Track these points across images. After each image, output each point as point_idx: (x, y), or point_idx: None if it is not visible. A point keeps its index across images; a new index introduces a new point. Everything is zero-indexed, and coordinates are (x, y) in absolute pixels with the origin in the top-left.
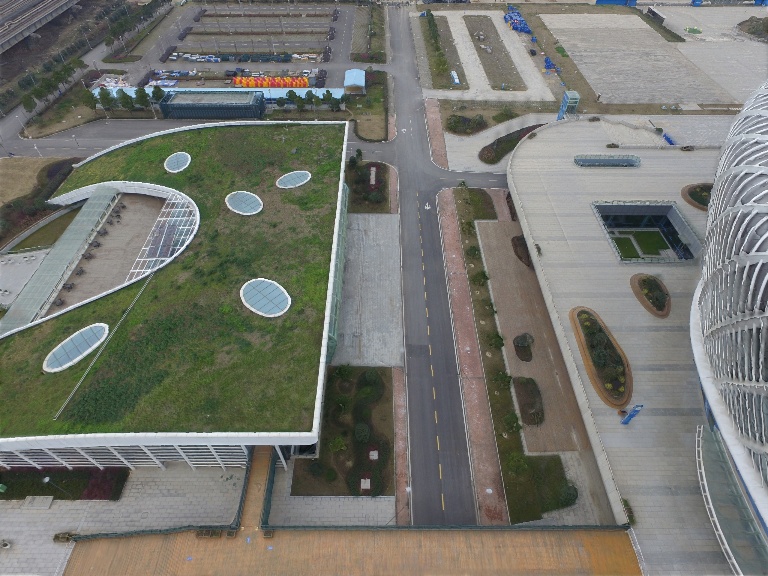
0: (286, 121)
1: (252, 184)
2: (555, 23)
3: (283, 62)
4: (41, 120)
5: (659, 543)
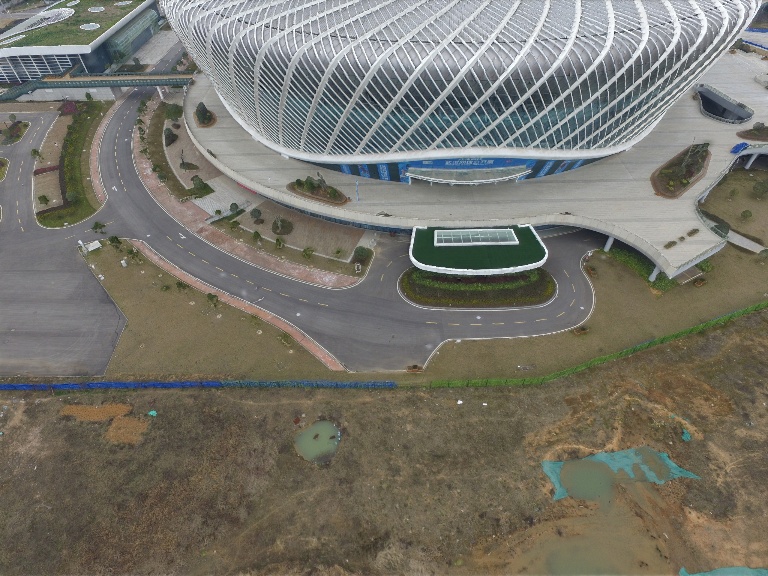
0: None
1: (103, 5)
2: None
3: None
4: (14, 5)
5: None
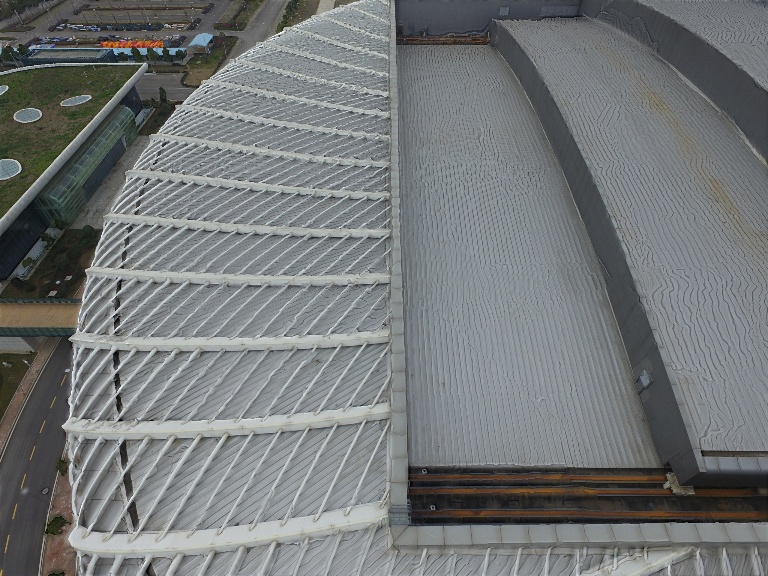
0: (96, 63)
1: (42, 104)
2: None
3: (154, 30)
4: None
5: None
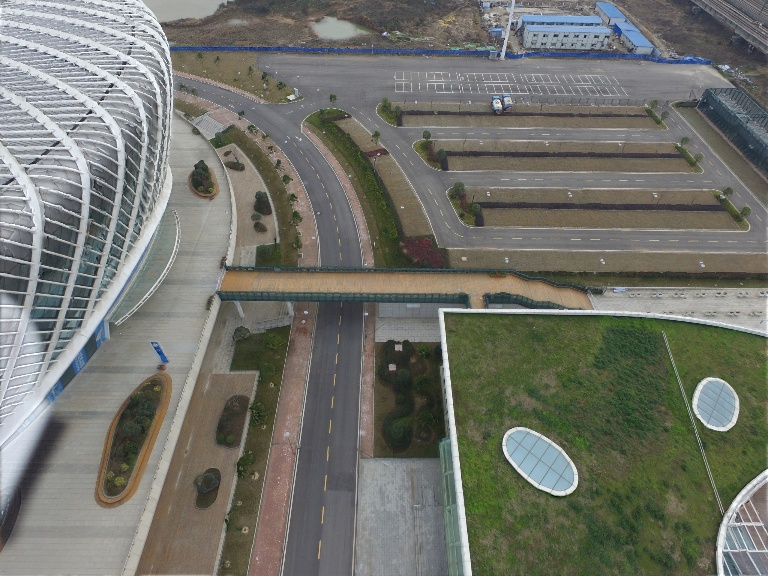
0: None
1: None
2: None
3: None
4: None
5: (202, 289)
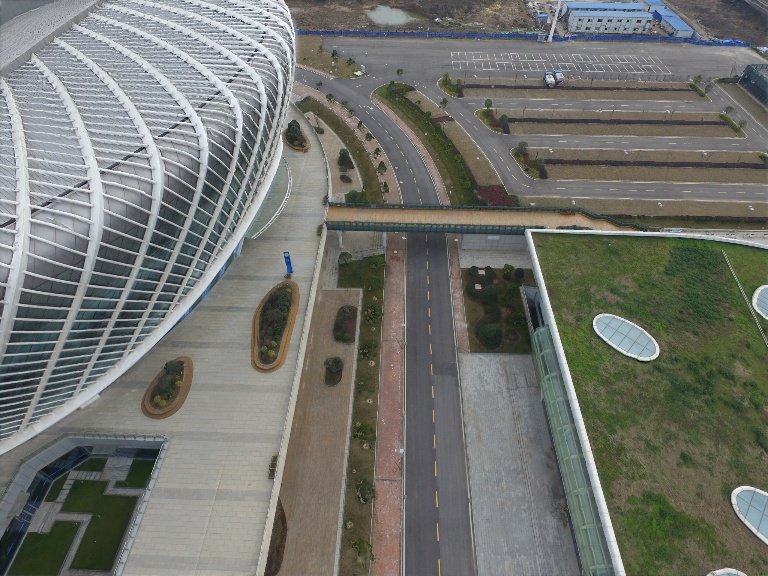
0: None
1: None
2: None
3: None
4: None
5: (310, 220)
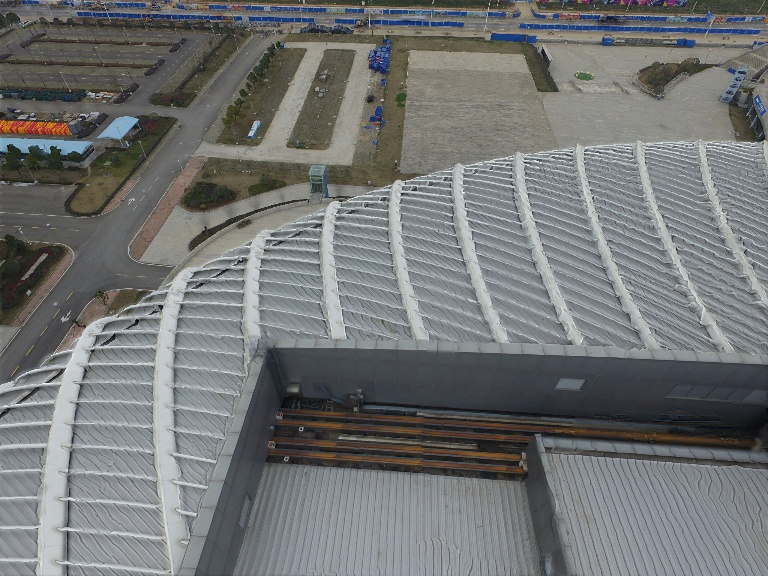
0: None
1: None
2: (420, 62)
3: (71, 101)
4: None
5: None
